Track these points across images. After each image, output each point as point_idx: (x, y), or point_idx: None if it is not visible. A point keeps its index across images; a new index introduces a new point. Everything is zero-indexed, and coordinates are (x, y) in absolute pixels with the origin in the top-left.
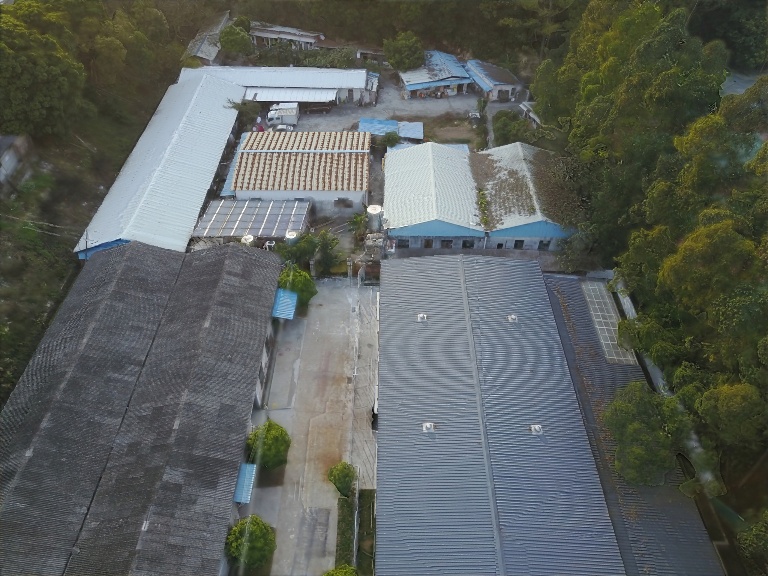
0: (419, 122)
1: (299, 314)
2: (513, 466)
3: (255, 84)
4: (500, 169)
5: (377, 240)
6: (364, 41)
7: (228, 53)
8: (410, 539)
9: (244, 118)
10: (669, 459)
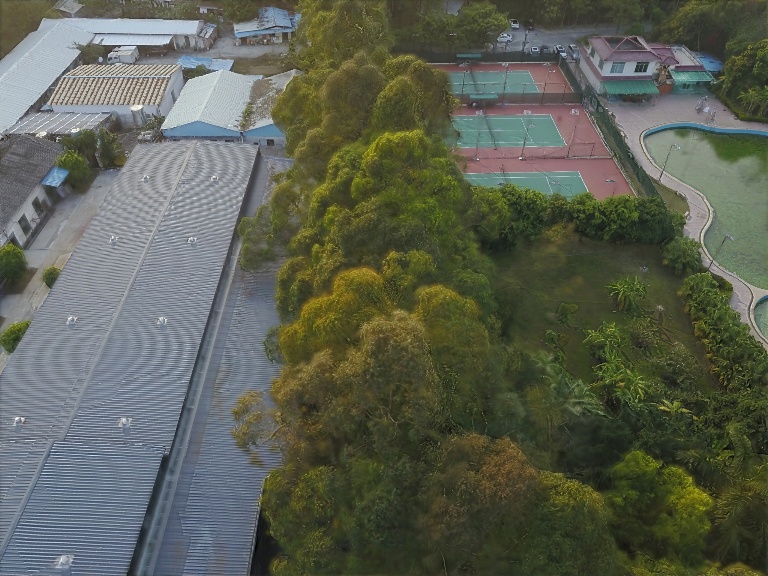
0: (231, 59)
1: (80, 192)
2: (161, 259)
3: (103, 31)
4: (272, 89)
5: (146, 135)
6: (217, 1)
7: (95, 10)
8: (67, 298)
9: (86, 57)
10: (270, 252)
